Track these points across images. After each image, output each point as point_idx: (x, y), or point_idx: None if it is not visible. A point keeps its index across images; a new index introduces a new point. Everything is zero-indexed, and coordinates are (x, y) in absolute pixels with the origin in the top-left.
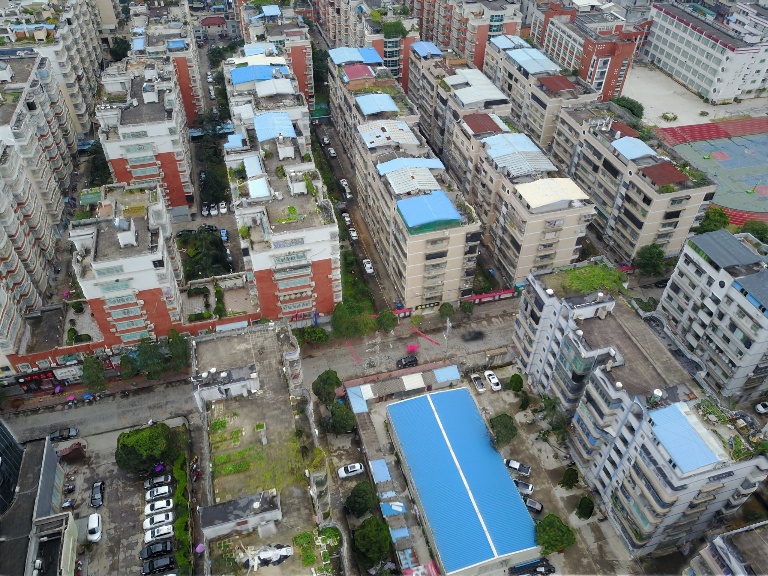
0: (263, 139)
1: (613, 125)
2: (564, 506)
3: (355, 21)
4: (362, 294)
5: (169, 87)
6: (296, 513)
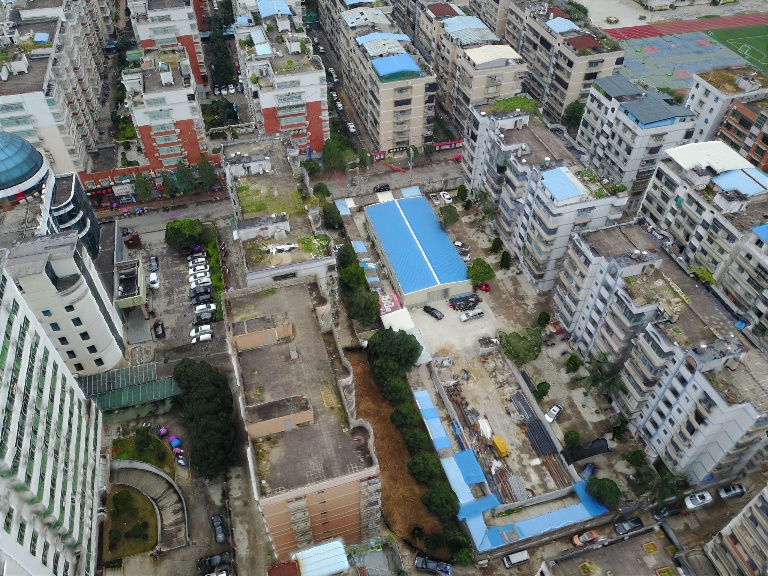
0: (265, 15)
1: (549, 10)
2: (493, 268)
3: None
4: (347, 146)
5: None
6: (299, 229)
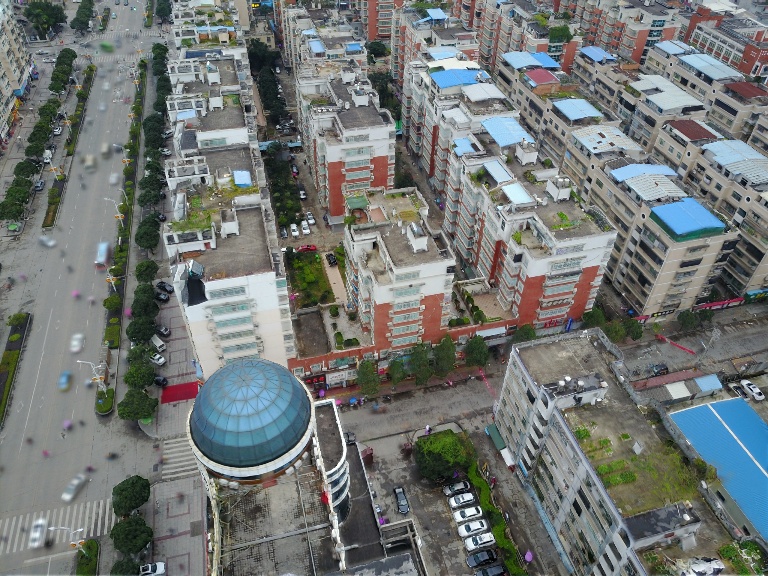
0: (505, 144)
1: None
2: None
3: (510, 25)
4: None
5: (371, 90)
6: (705, 525)
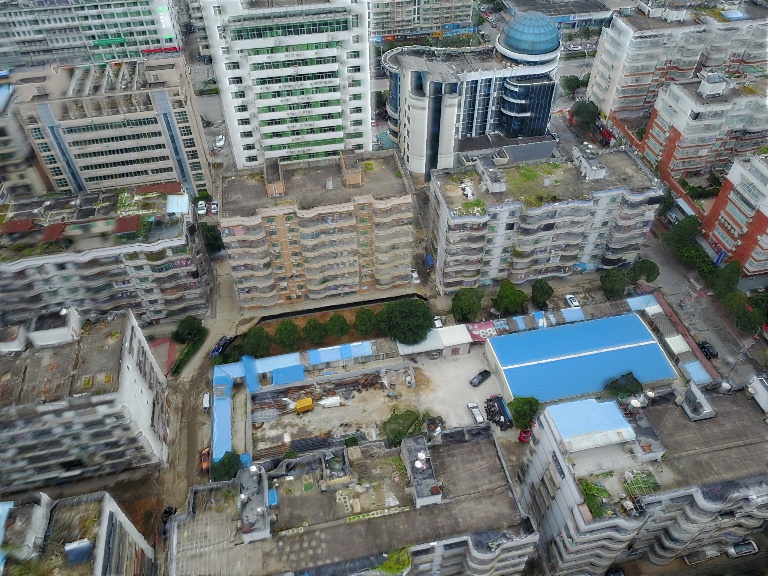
0: None
1: None
2: None
3: None
4: None
5: None
6: (495, 200)
